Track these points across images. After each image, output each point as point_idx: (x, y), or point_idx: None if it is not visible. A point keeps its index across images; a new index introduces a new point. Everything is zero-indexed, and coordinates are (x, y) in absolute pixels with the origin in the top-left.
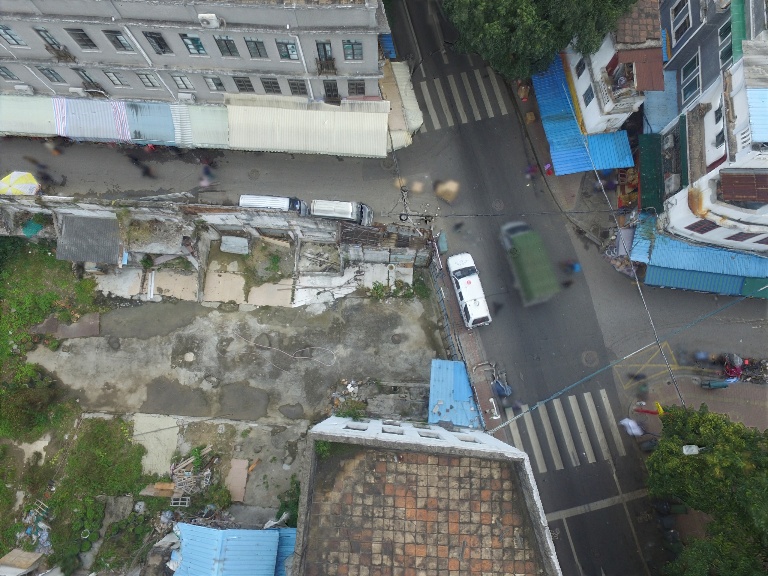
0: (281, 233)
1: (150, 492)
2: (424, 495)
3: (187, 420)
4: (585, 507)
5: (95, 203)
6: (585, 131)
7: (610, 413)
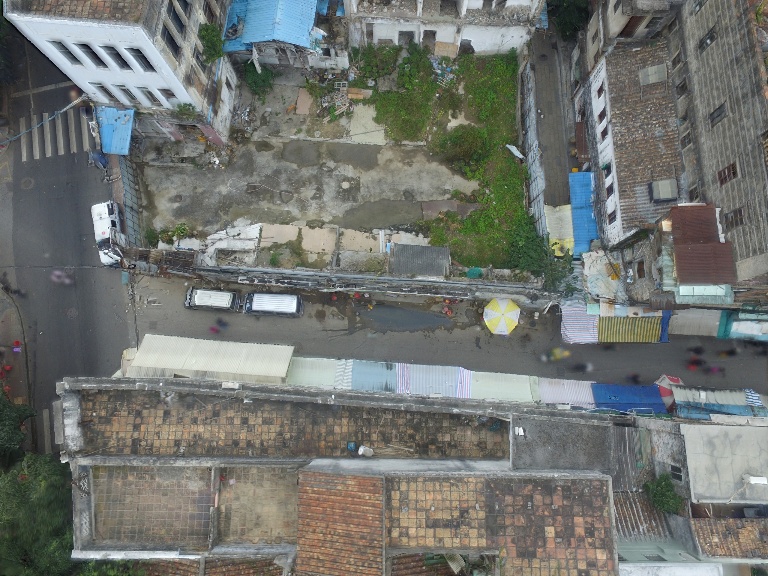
0: (271, 289)
1: (365, 92)
2: (85, 7)
3: (344, 140)
4: (59, 86)
5: (397, 274)
6: None
7: (23, 145)
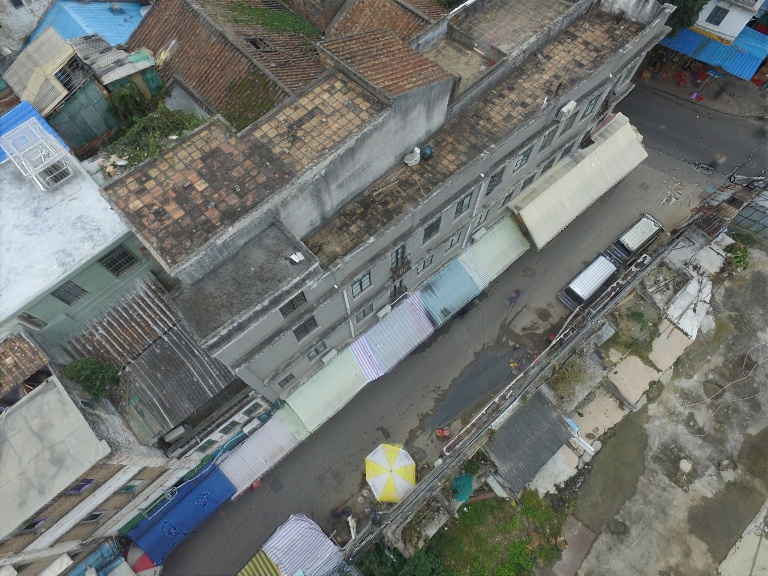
0: None
1: None
2: None
3: (759, 522)
4: None
5: (540, 384)
6: (729, 42)
7: None
